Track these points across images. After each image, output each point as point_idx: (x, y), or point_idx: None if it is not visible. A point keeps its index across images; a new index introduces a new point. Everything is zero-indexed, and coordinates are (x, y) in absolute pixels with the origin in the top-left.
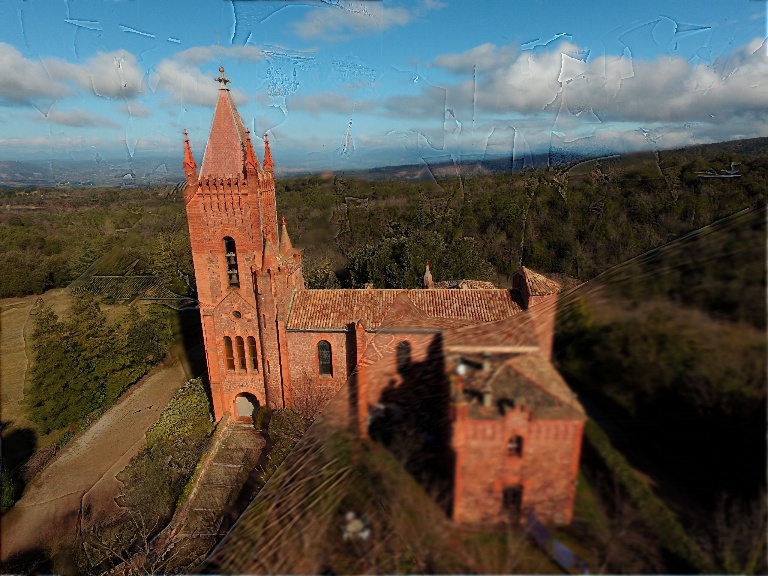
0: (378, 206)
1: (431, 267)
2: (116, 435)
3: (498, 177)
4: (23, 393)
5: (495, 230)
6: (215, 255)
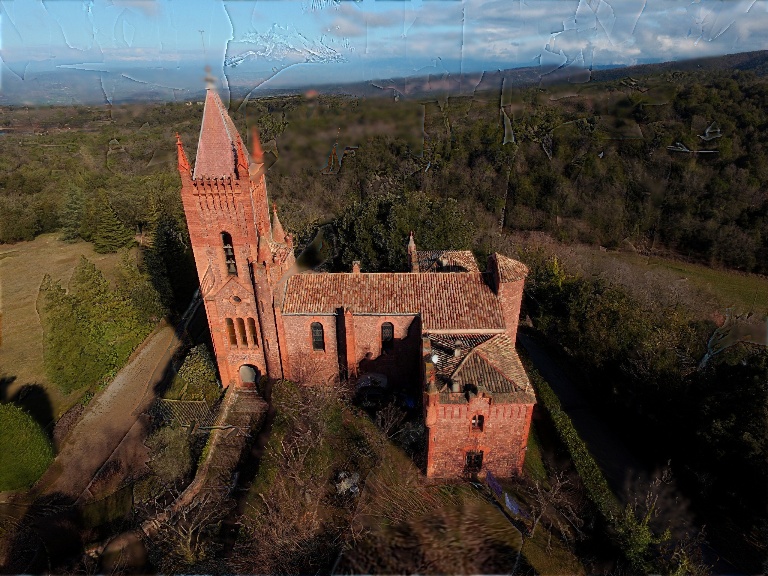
0: (365, 151)
1: (416, 228)
2: (132, 394)
3: (485, 124)
4: (44, 361)
5: (481, 178)
6: (213, 248)
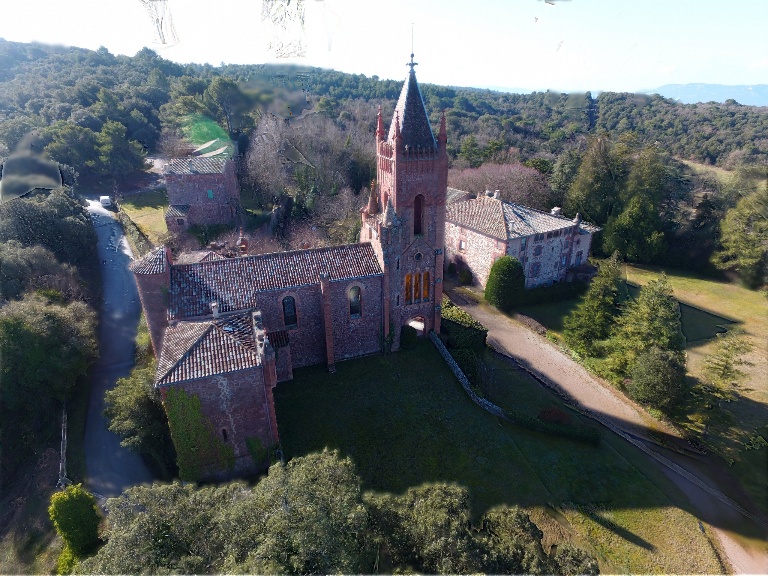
0: None
1: None
2: (531, 352)
3: None
4: None
5: None
6: None
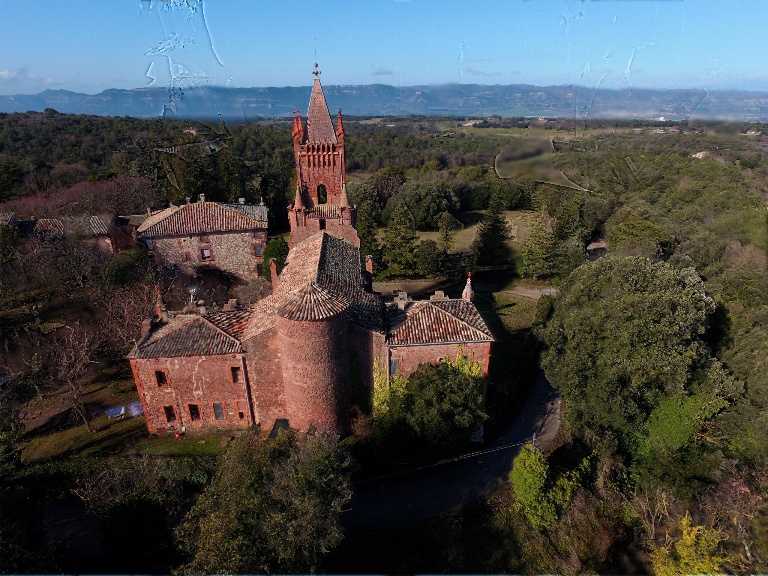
0: None
1: None
2: None
3: None
4: None
5: None
6: None
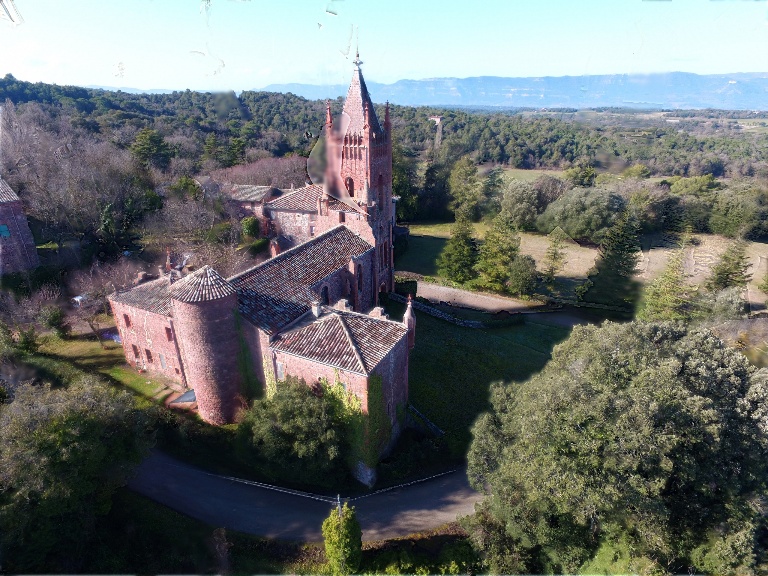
0: None
1: None
2: (428, 293)
3: None
4: None
5: None
6: None
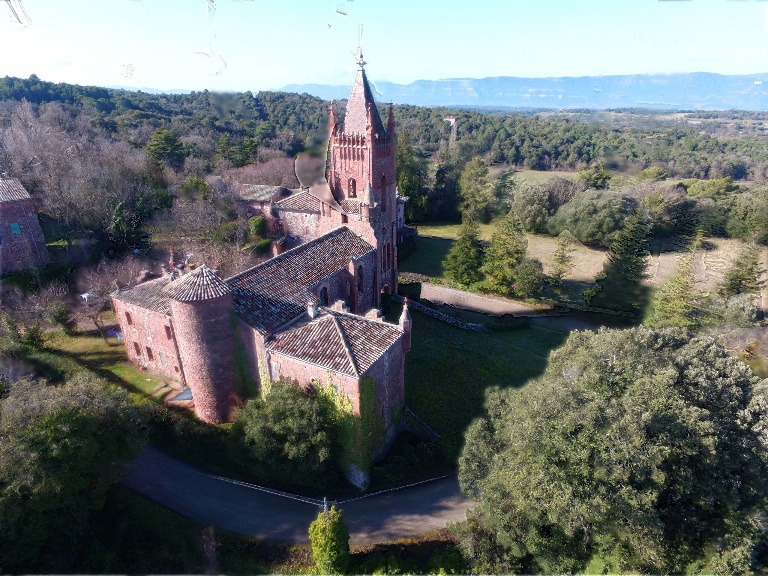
0: None
1: None
2: None
3: None
4: None
5: None
6: None
